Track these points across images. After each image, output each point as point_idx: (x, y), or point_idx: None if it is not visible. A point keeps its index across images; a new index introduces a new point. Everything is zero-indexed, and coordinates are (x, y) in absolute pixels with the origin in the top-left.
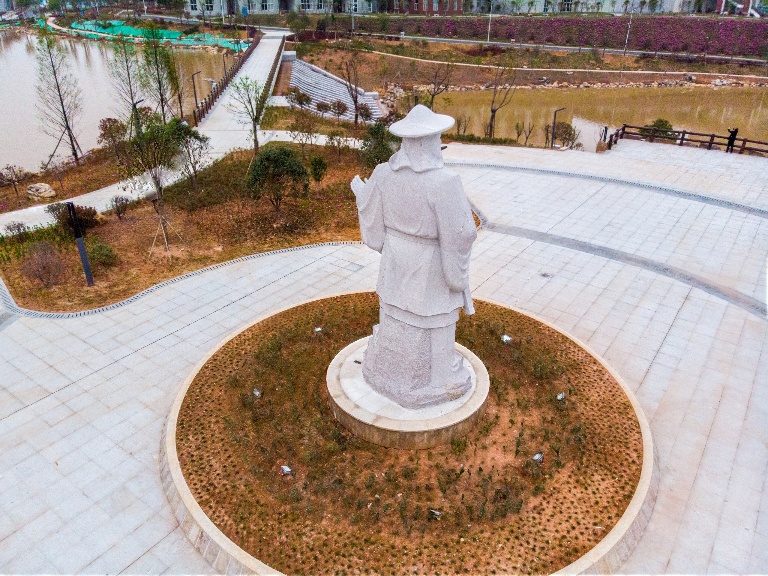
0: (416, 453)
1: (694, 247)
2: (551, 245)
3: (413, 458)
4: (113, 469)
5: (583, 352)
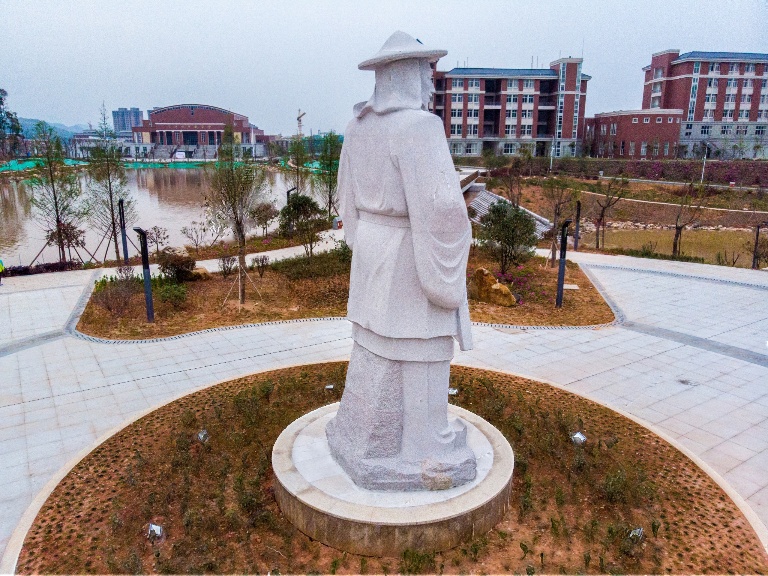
0: (344, 556)
1: None
2: (707, 351)
3: None
4: None
5: (705, 479)
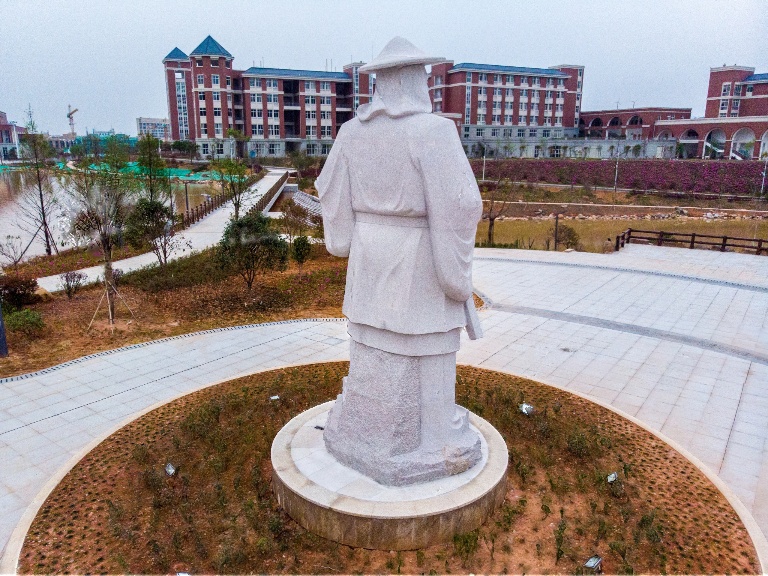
0: (398, 554)
1: (739, 325)
2: (569, 322)
3: (393, 563)
4: None
5: (632, 425)
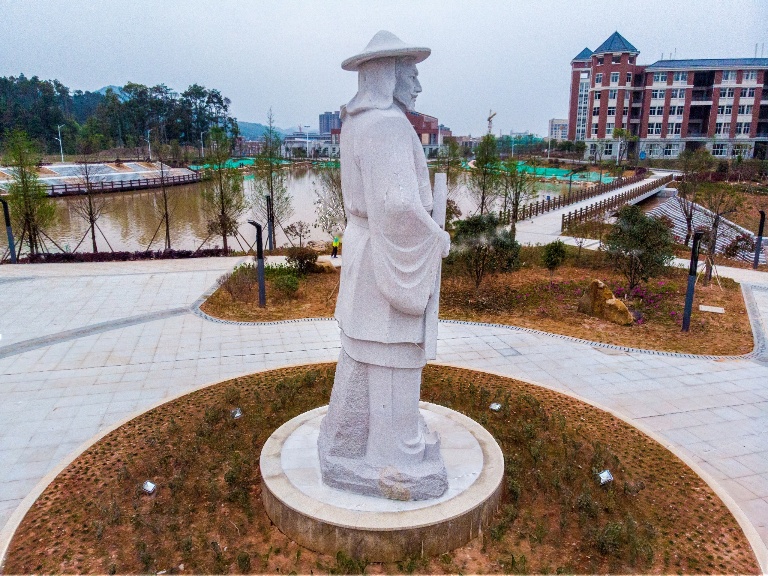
0: None
1: None
2: None
3: (280, 550)
4: (74, 429)
5: (744, 553)
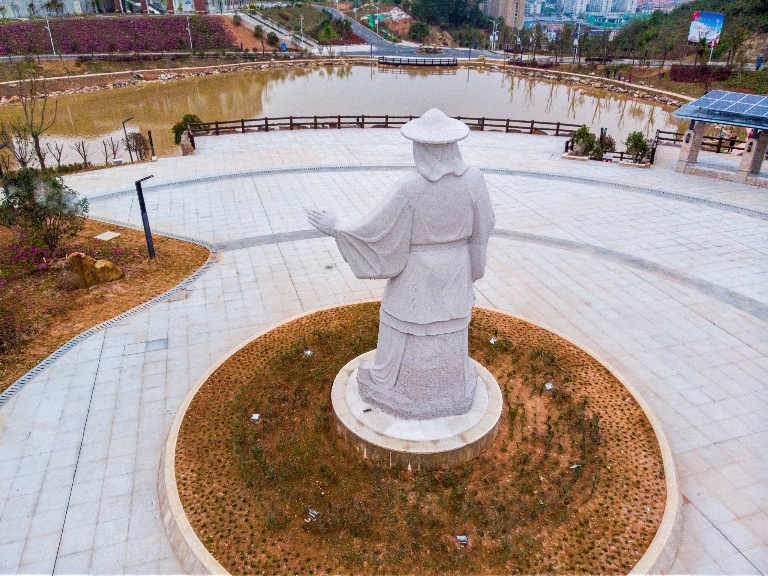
0: (504, 442)
1: None
2: (294, 242)
3: (504, 448)
4: None
5: None
